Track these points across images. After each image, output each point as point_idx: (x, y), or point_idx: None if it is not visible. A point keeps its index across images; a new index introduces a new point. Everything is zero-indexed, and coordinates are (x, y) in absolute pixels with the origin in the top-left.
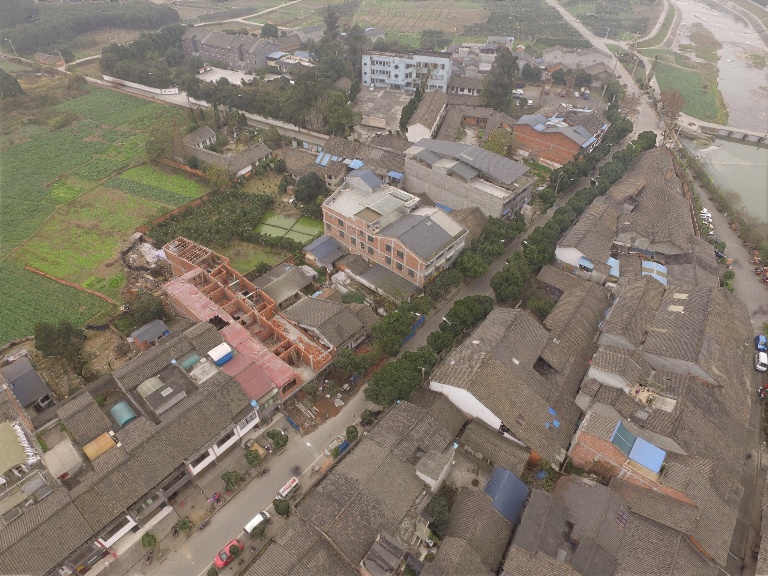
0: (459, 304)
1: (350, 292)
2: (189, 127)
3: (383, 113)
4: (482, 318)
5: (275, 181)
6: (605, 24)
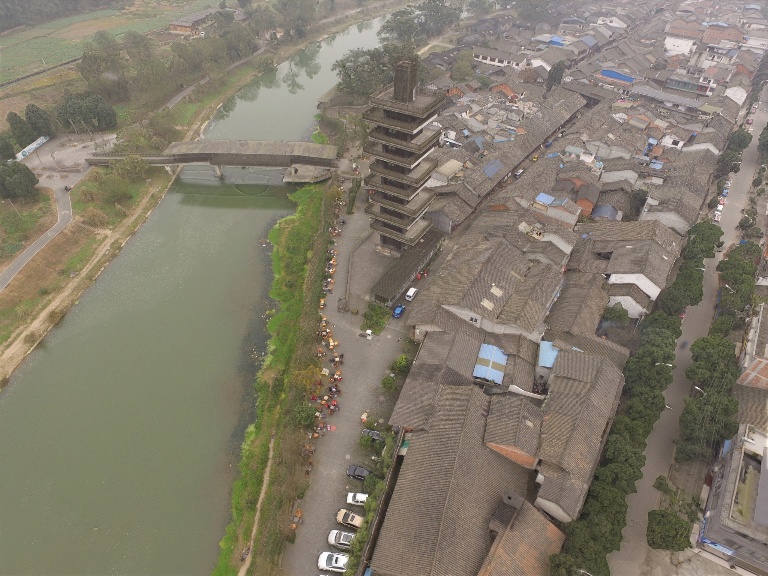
0: None
1: None
2: None
3: None
4: None
5: None
6: None
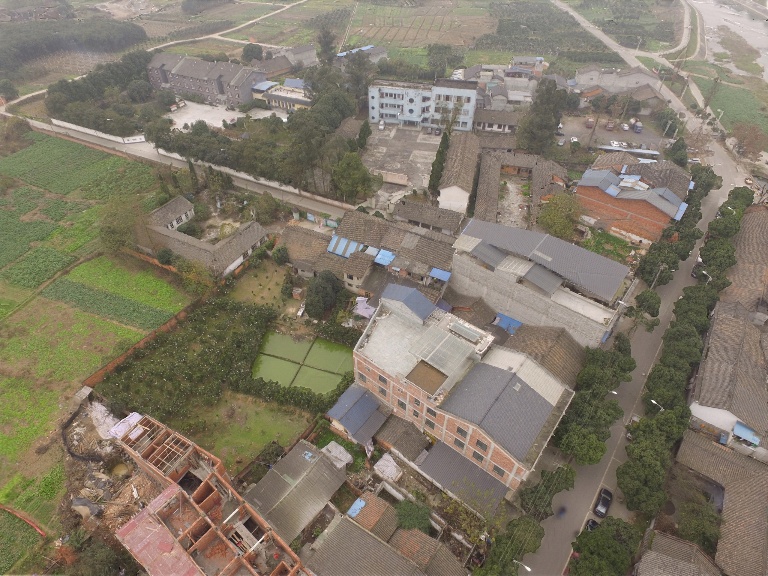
0: (592, 549)
1: (408, 504)
2: (158, 199)
3: (400, 162)
4: (628, 568)
5: (275, 277)
6: (629, 31)
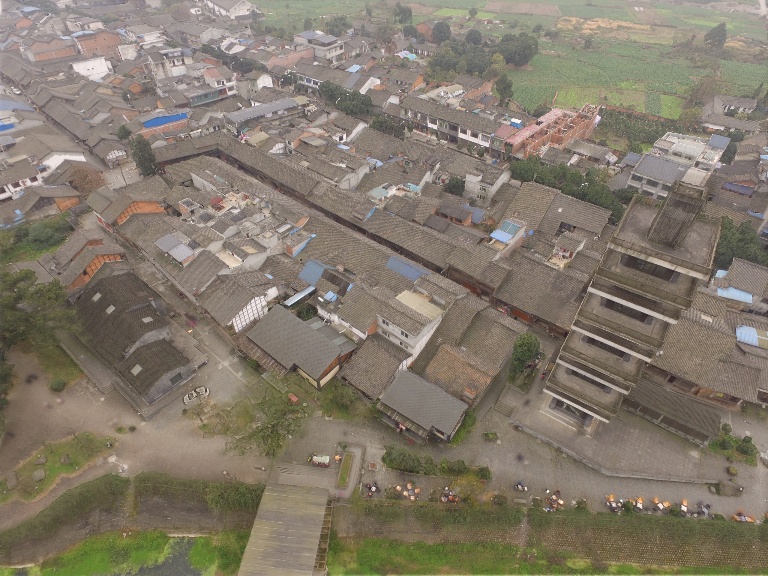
0: None
1: None
2: (744, 94)
3: None
4: None
5: None
6: None
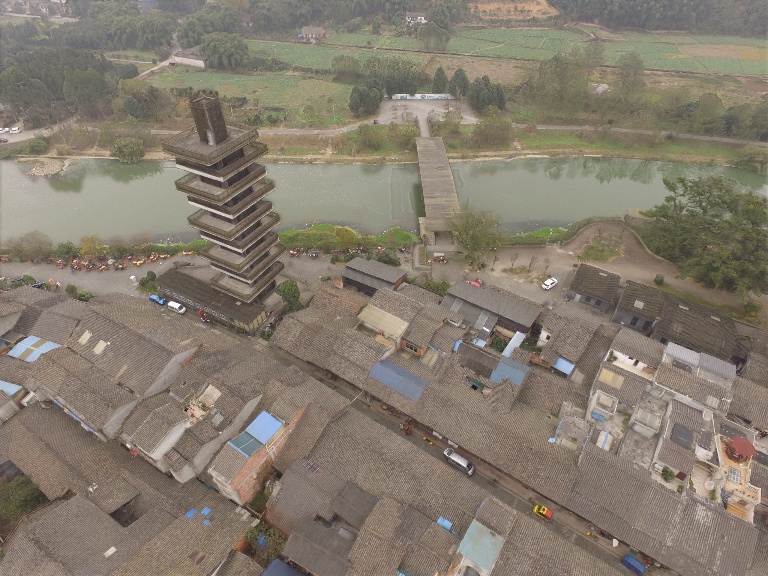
0: None
1: None
2: None
3: None
4: None
5: None
6: None
